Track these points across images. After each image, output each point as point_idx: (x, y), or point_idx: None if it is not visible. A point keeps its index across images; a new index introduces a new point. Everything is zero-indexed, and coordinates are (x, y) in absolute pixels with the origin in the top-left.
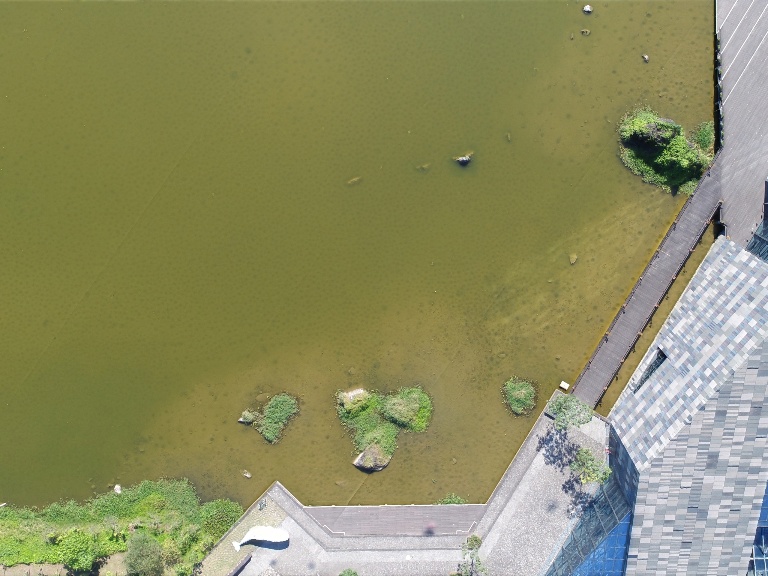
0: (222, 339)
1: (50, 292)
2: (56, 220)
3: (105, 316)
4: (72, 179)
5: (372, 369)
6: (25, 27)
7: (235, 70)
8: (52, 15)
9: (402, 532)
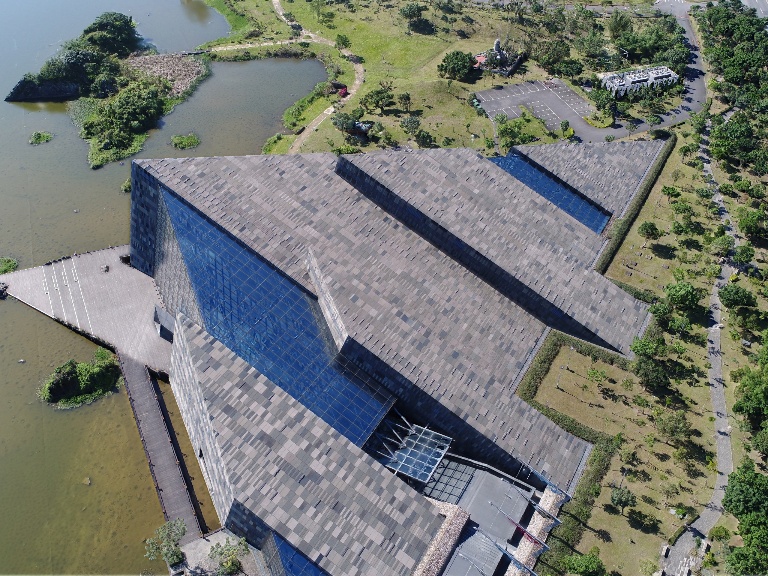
0: None
1: None
2: None
3: None
4: None
5: None
6: None
7: None
8: None
9: None
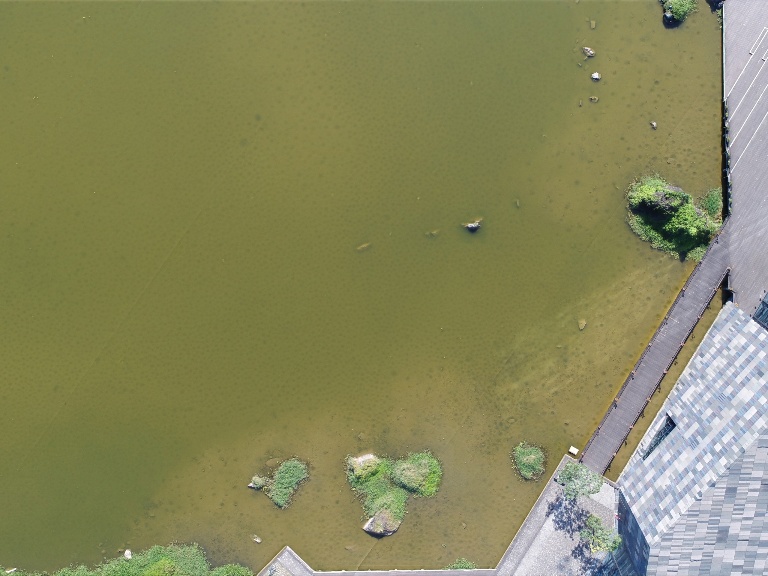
0: (232, 404)
1: (60, 358)
2: (66, 286)
3: (115, 382)
4: (82, 245)
5: (382, 434)
6: (35, 94)
7: (245, 137)
8: (62, 82)
9: None
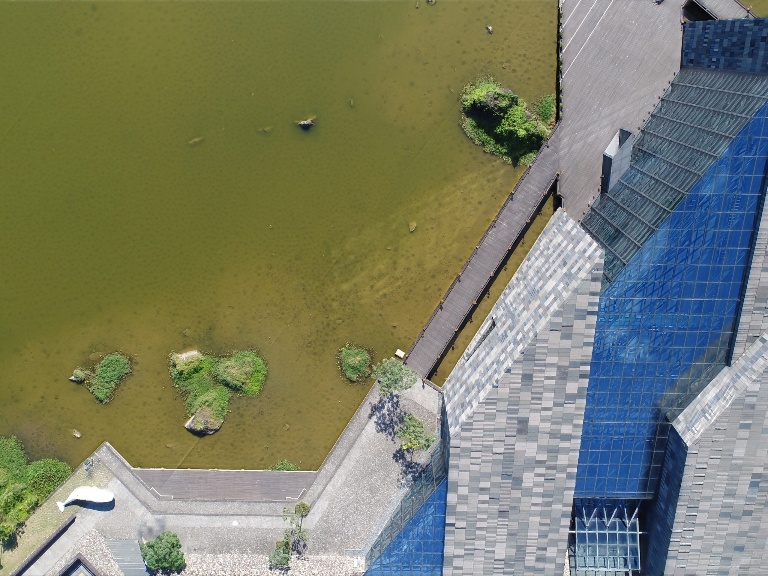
0: (57, 296)
1: None
2: None
3: None
4: None
5: (207, 331)
6: None
7: (80, 27)
8: None
9: (231, 497)
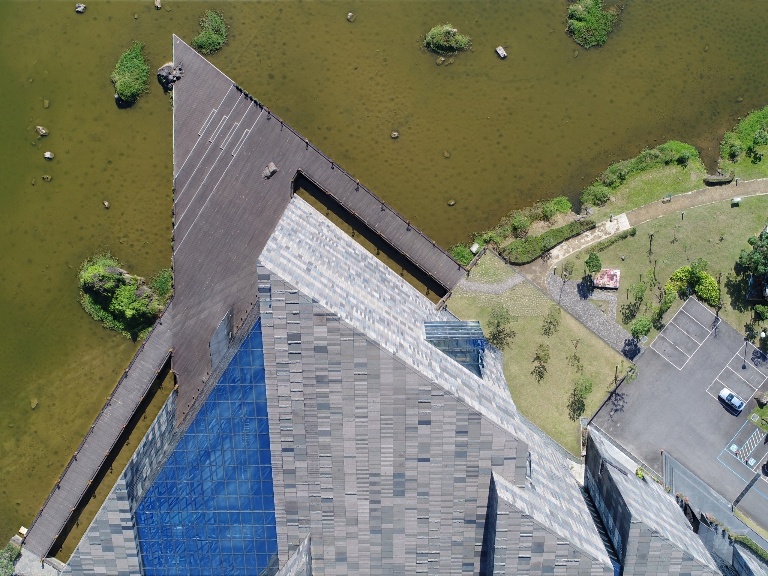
0: None
1: None
2: None
3: None
4: None
5: None
6: None
7: None
8: None
9: None
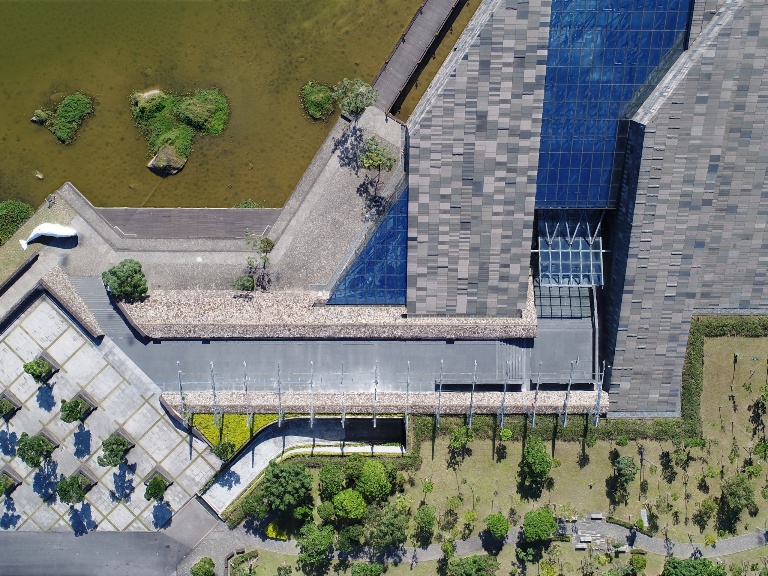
0: (17, 37)
1: None
2: None
3: None
4: None
5: (169, 71)
6: None
7: None
8: None
9: (195, 235)
